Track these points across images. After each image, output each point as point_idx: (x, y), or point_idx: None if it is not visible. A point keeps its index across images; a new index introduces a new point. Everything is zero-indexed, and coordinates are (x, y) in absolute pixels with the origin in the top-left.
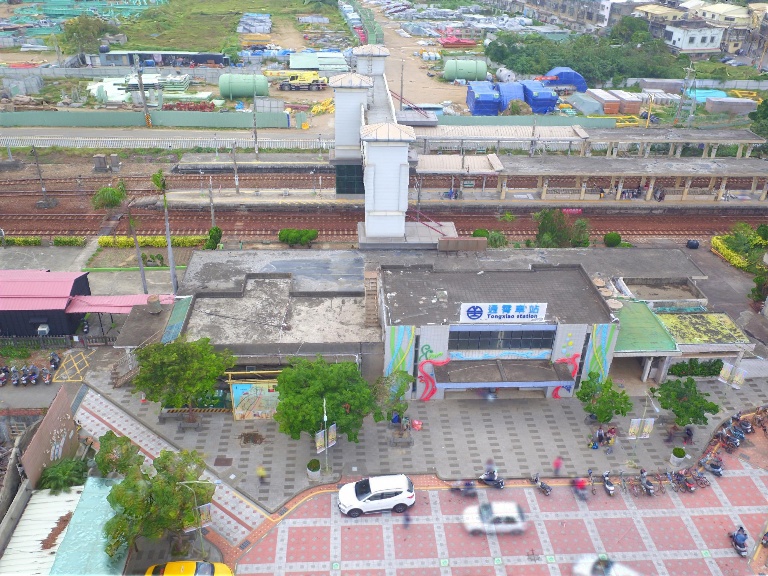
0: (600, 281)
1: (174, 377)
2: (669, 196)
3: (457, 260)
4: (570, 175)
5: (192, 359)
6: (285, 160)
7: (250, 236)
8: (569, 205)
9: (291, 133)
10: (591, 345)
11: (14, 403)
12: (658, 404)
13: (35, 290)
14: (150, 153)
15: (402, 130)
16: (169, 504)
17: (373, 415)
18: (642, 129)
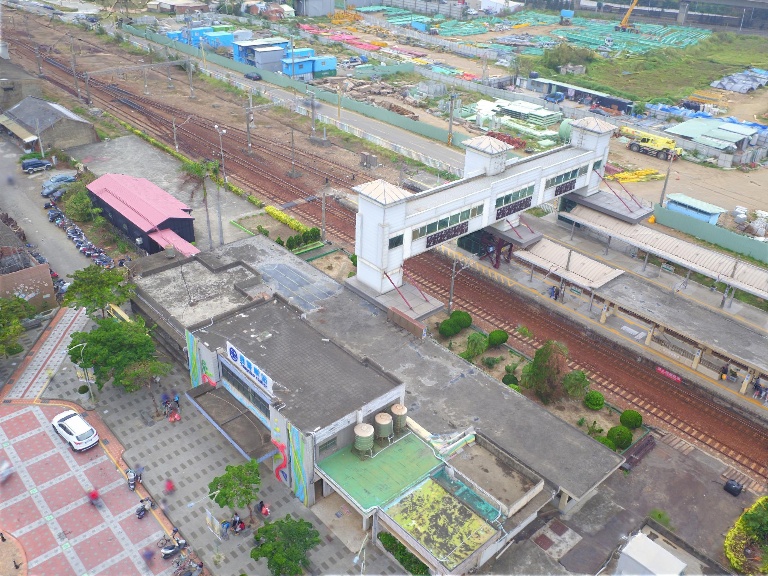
0: (399, 408)
1: None
2: None
3: (391, 334)
4: (671, 329)
5: (97, 284)
6: None
7: None
8: (666, 365)
9: None
10: None
11: None
12: (333, 551)
13: (150, 214)
14: (413, 164)
15: (385, 192)
16: None
17: None
18: None
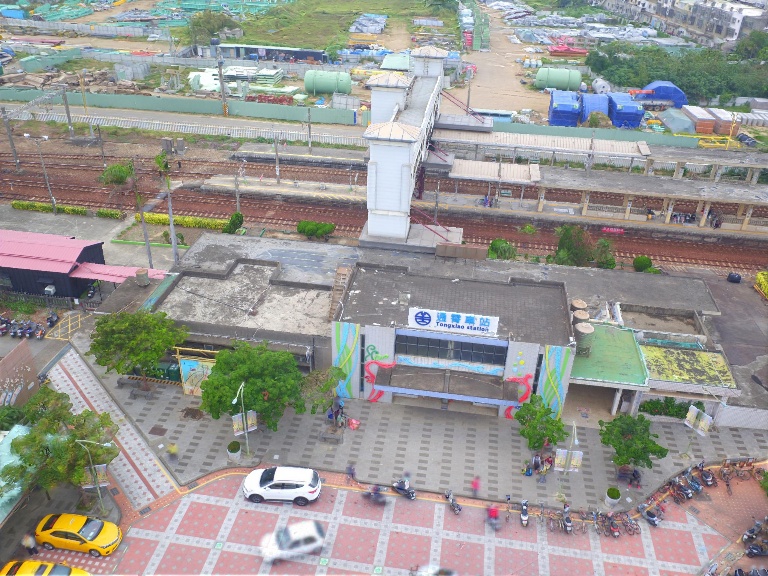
0: (581, 303)
1: (120, 344)
2: (726, 224)
3: (453, 267)
4: (612, 192)
5: (143, 330)
6: (336, 155)
7: (276, 225)
8: (610, 224)
9: (355, 130)
10: (544, 367)
11: (5, 352)
12: None
13: (48, 253)
14: (217, 140)
15: (405, 130)
16: (61, 458)
17: (295, 406)
18: (717, 150)
